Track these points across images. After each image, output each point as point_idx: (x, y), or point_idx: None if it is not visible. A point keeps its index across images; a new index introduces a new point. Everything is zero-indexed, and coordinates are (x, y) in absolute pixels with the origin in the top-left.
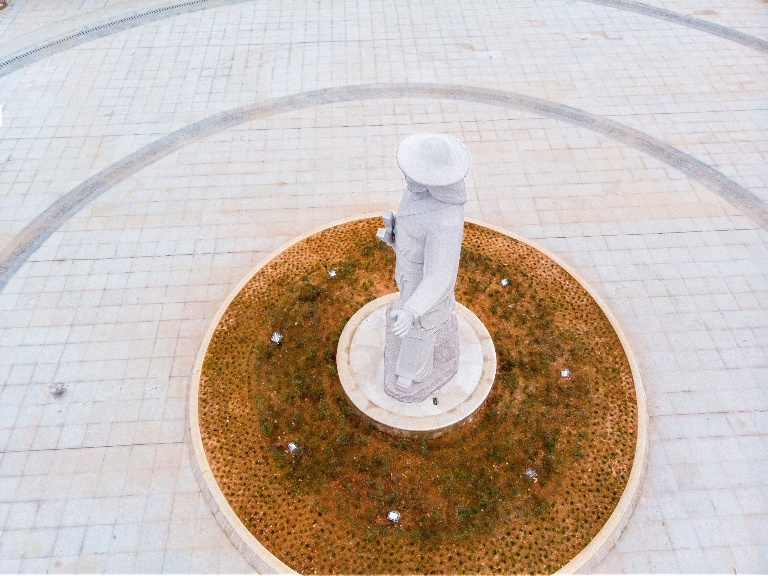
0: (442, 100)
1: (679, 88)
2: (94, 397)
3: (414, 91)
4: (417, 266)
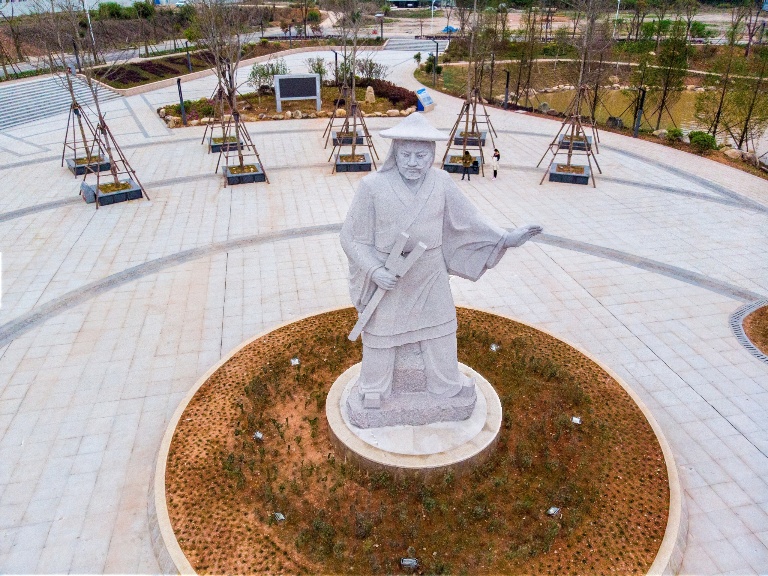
0: None
1: (17, 266)
2: None
3: None
4: None
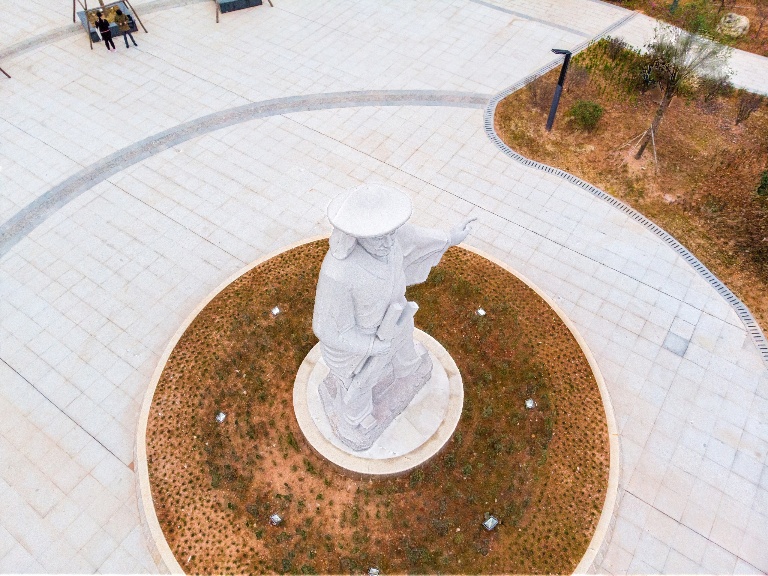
0: None
1: None
2: None
3: None
4: None
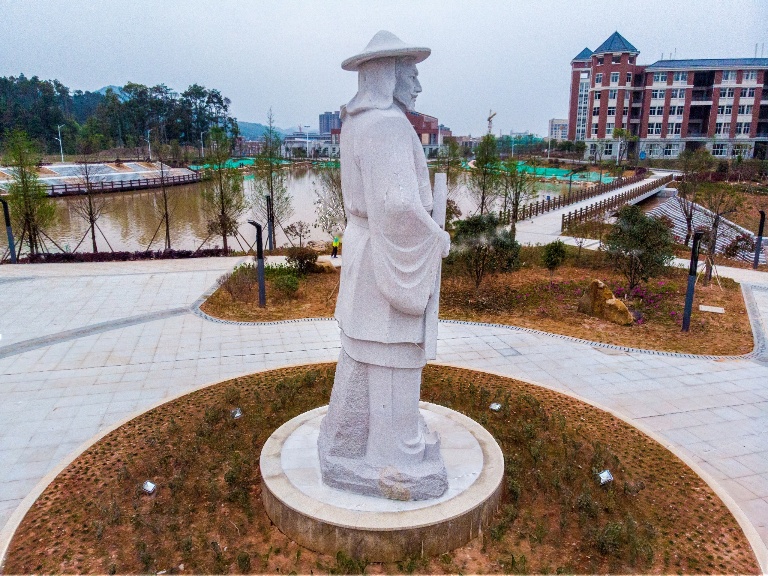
0: None
1: None
2: (761, 437)
3: None
4: None
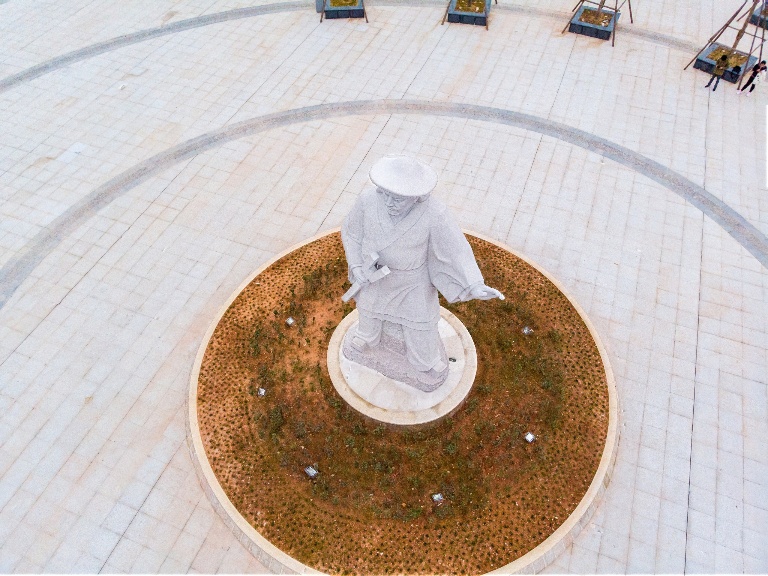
0: (99, 213)
1: (234, 74)
2: None
3: (63, 228)
4: (422, 268)
